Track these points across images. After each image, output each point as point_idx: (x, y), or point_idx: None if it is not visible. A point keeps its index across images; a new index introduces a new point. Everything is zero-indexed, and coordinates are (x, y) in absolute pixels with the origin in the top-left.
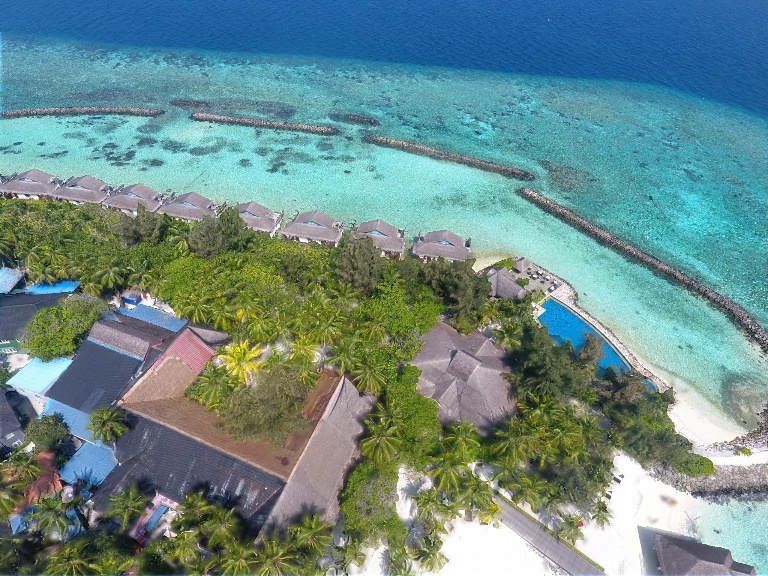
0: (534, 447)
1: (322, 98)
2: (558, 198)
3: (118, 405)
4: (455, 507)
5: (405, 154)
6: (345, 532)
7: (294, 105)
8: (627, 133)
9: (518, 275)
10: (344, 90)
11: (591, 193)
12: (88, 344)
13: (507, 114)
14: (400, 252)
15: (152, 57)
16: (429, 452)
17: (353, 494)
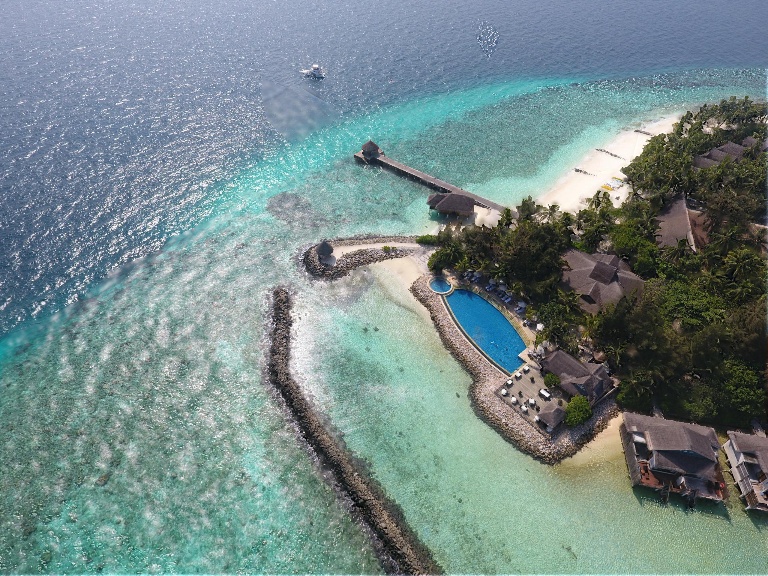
0: None
1: None
2: None
3: None
4: None
5: None
6: None
7: None
8: None
9: None
10: None
11: None
12: None
13: None
14: None
15: None
16: None
17: None
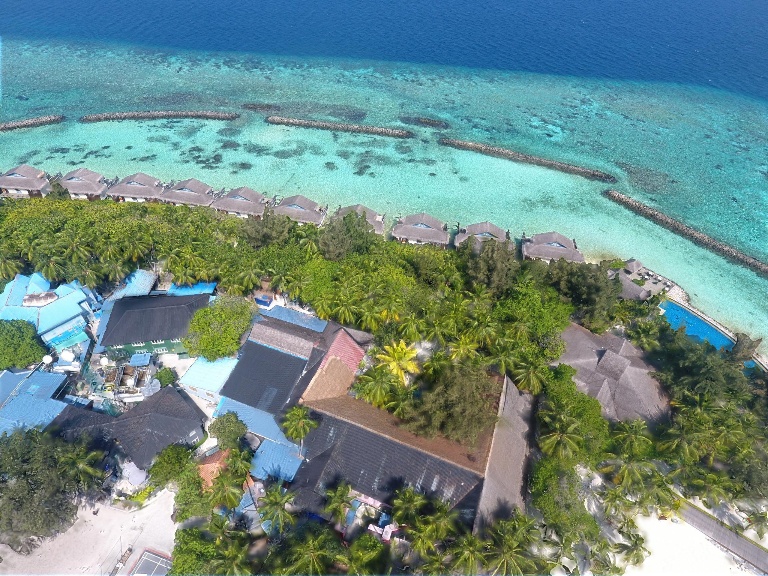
0: (704, 444)
1: (388, 101)
2: (644, 200)
3: (300, 403)
4: (643, 502)
5: (484, 157)
6: (547, 526)
7: (363, 108)
8: (695, 135)
9: (629, 276)
10: (407, 93)
11: (675, 195)
12: (250, 344)
13: (572, 116)
14: None
15: (212, 61)
16: (605, 449)
17: (548, 489)
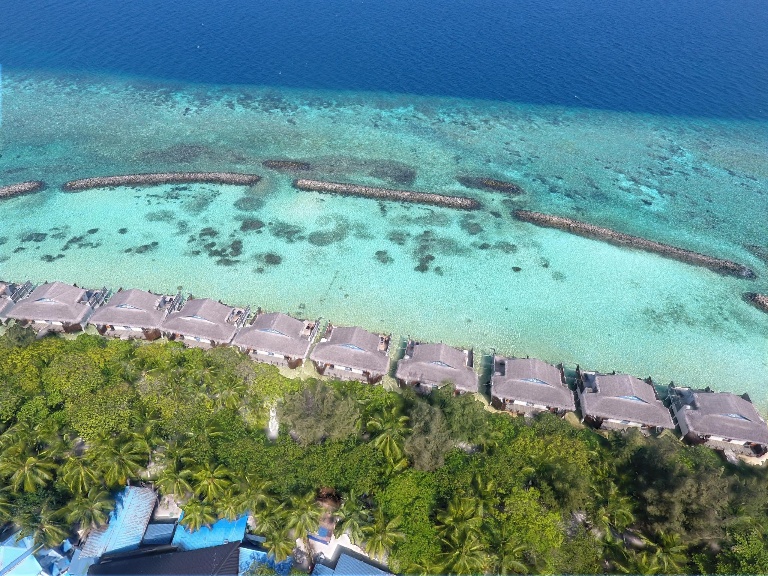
0: None
1: (439, 153)
2: None
3: None
4: None
5: (575, 238)
6: None
7: (410, 164)
8: None
9: None
10: (460, 141)
11: None
12: None
13: (667, 173)
14: (669, 428)
15: (223, 98)
16: None
17: None
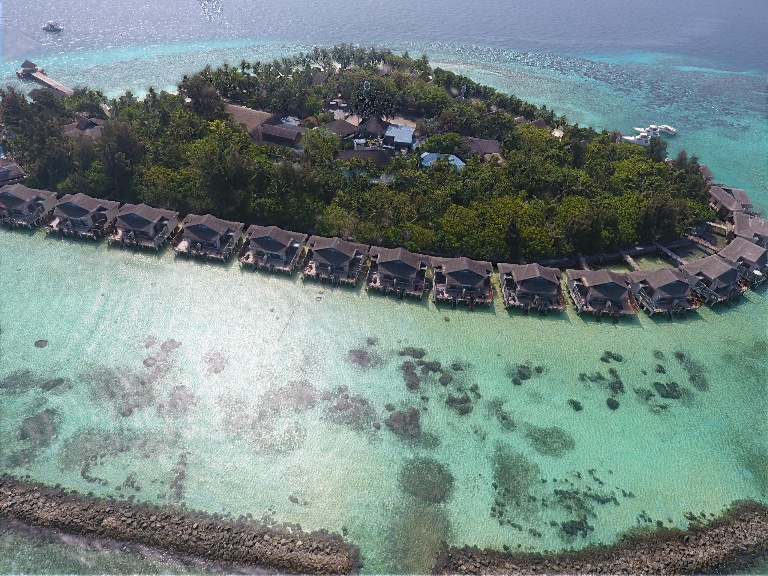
0: None
1: None
2: None
3: None
4: None
5: None
6: None
7: None
8: None
9: None
10: None
11: None
12: None
13: None
14: None
15: None
16: None
17: None
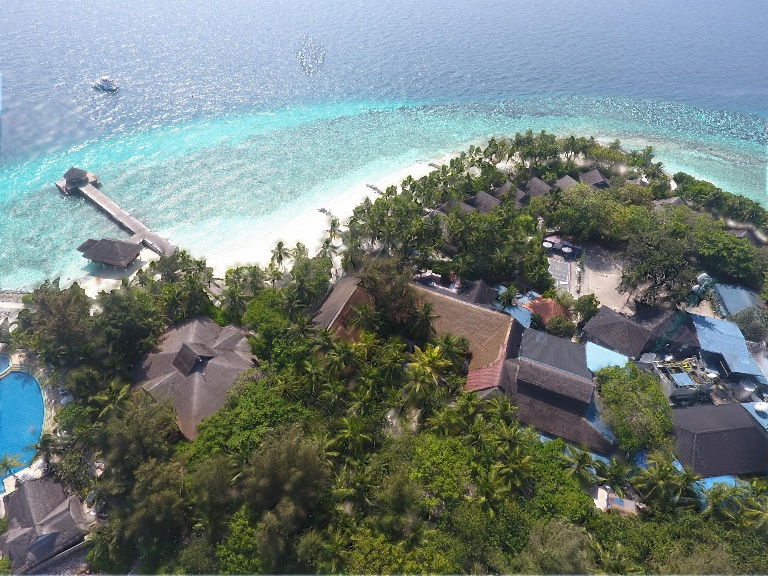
0: None
1: None
2: None
3: (512, 317)
4: None
5: None
6: None
7: None
8: None
9: None
10: None
11: None
12: (586, 376)
13: None
14: None
15: None
16: None
17: None
